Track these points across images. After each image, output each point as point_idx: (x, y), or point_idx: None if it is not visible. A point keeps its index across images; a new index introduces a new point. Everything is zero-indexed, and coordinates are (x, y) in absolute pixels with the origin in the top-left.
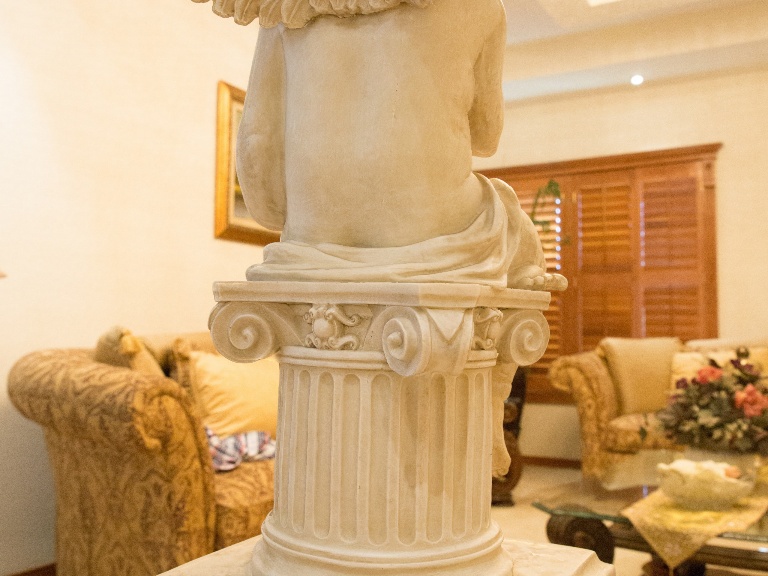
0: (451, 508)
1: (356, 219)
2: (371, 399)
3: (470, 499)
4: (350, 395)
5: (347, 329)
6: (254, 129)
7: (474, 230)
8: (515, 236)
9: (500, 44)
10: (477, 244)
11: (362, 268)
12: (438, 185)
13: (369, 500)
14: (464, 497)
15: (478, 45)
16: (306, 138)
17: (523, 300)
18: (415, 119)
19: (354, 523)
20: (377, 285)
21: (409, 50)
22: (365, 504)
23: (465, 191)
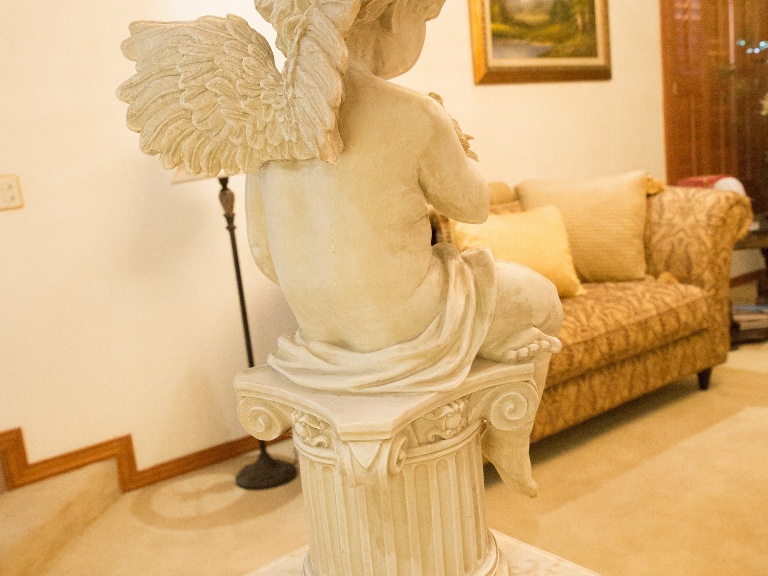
0: (420, 570)
1: (331, 327)
2: (342, 487)
3: (440, 560)
4: (329, 481)
5: (320, 430)
6: (254, 243)
7: (424, 338)
8: (483, 324)
9: (441, 152)
10: (427, 351)
11: (327, 380)
12: (384, 304)
13: (351, 562)
14: (434, 559)
15: (411, 165)
16: (279, 264)
17: (499, 378)
18: (351, 254)
19: (344, 575)
20: (322, 410)
21: (337, 193)
22: (348, 564)
23: (416, 301)
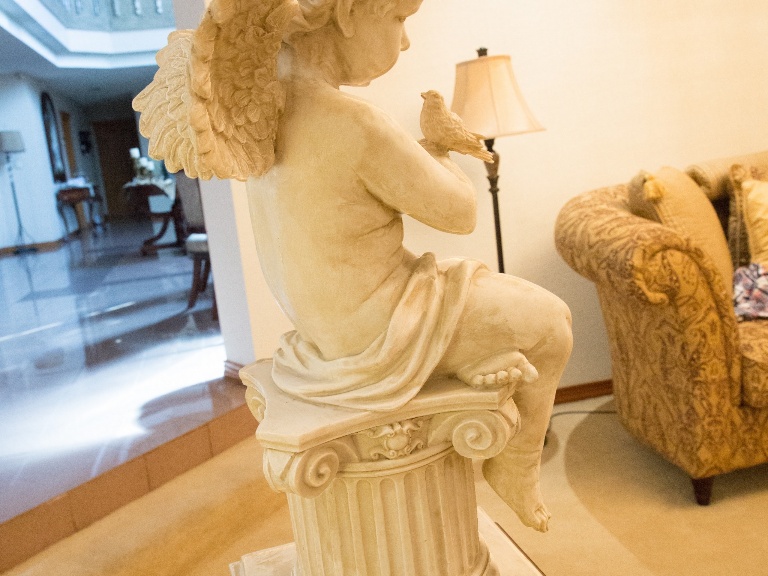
0: None
1: None
2: None
3: None
4: None
5: None
6: None
7: (365, 355)
8: (437, 345)
9: (382, 163)
10: (368, 368)
11: (288, 383)
12: (329, 316)
13: (309, 559)
14: None
15: (348, 177)
16: None
17: (458, 404)
18: (294, 264)
19: None
20: None
21: (279, 204)
22: (307, 561)
23: (361, 315)
